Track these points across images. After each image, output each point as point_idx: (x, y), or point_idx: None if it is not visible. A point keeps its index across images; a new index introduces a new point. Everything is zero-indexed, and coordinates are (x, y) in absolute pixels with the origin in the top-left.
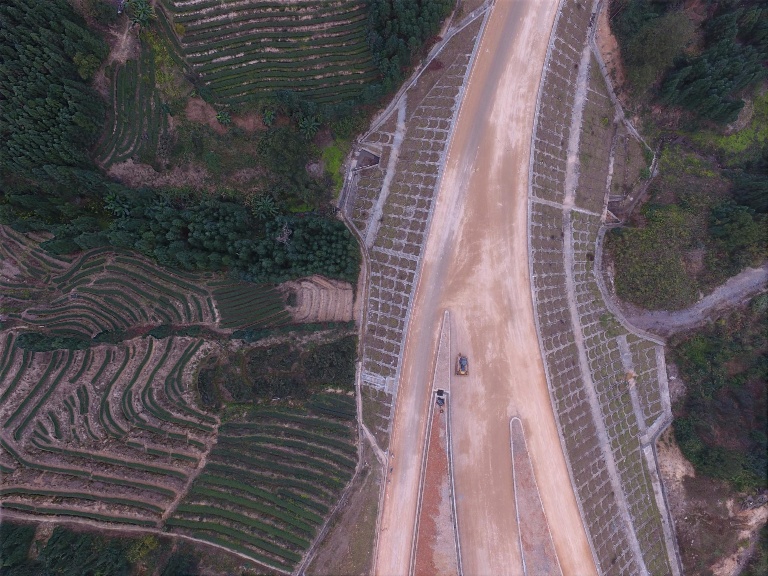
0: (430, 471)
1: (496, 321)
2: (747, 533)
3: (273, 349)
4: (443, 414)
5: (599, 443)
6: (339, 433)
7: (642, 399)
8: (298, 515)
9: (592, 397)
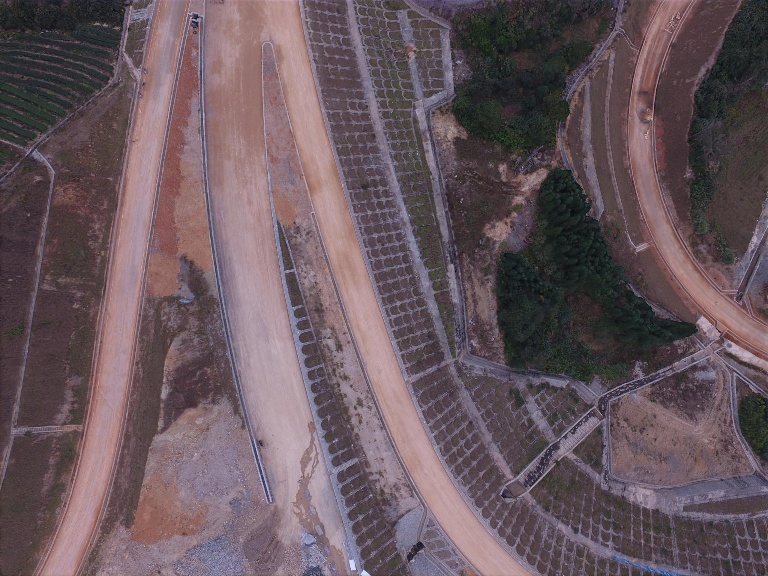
0: (181, 87)
1: None
2: (520, 199)
3: None
4: (196, 35)
5: (363, 89)
6: None
7: (422, 72)
8: (41, 107)
9: (358, 48)
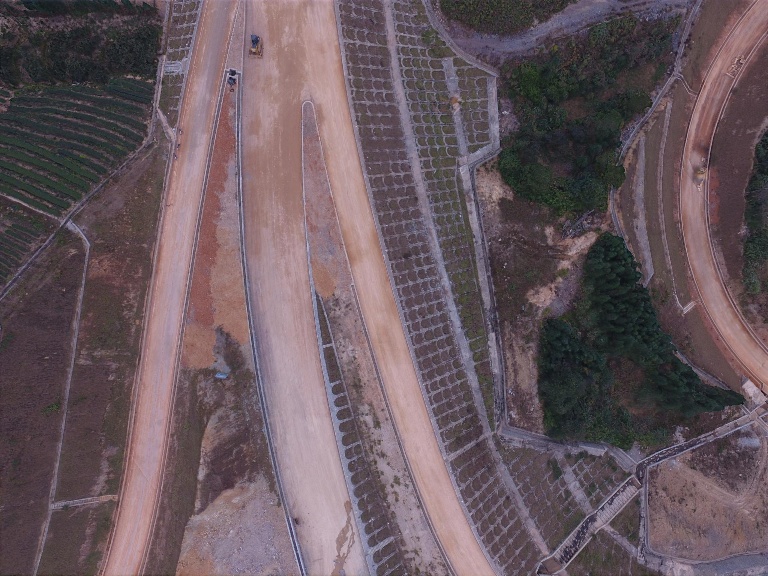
0: (217, 149)
1: (295, 5)
2: (567, 263)
3: (72, 32)
4: (233, 93)
5: (406, 148)
6: (131, 112)
7: (466, 125)
8: (74, 172)
9: (402, 103)
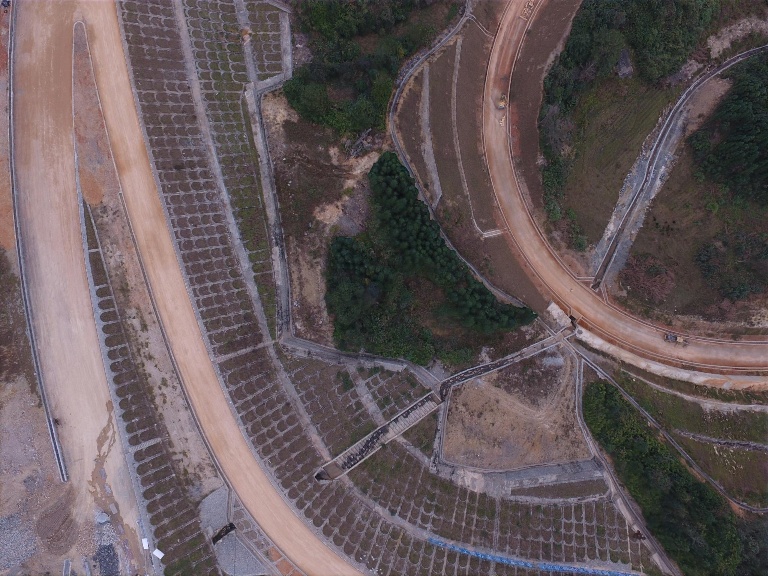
0: None
1: None
2: (352, 183)
3: None
4: (7, 14)
5: (185, 71)
6: None
7: (257, 55)
8: None
9: (183, 29)
